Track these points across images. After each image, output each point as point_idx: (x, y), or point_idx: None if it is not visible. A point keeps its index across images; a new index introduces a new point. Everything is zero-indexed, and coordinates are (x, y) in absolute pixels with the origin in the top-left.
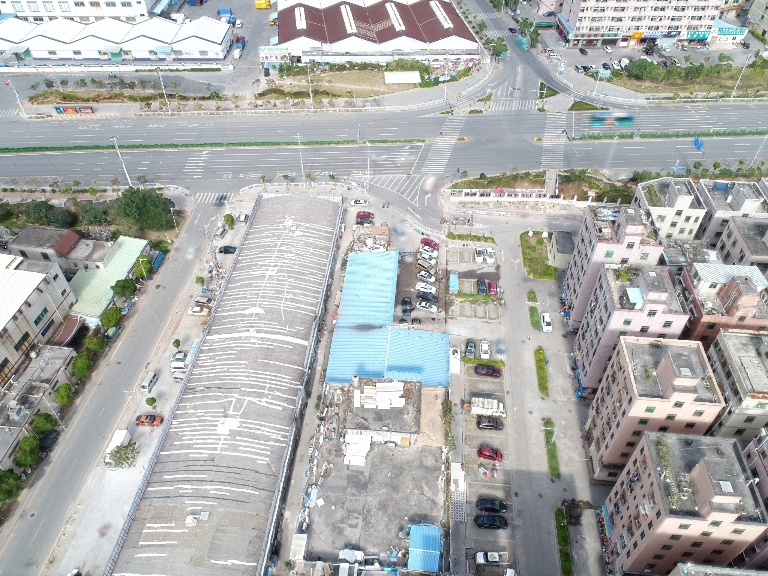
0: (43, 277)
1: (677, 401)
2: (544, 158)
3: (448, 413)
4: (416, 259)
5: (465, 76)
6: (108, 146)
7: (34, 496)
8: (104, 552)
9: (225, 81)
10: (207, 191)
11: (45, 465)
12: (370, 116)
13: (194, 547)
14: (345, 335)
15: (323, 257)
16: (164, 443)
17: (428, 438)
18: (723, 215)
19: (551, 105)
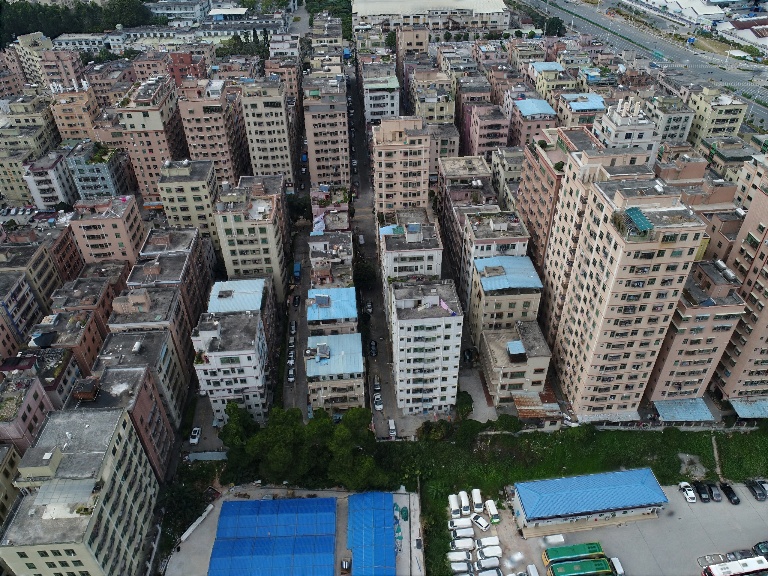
0: (503, 12)
1: None
2: None
3: None
4: None
5: (766, 64)
6: None
7: None
8: None
9: None
10: None
11: None
12: None
13: None
14: None
15: None
16: None
17: None
18: None
19: (762, 83)
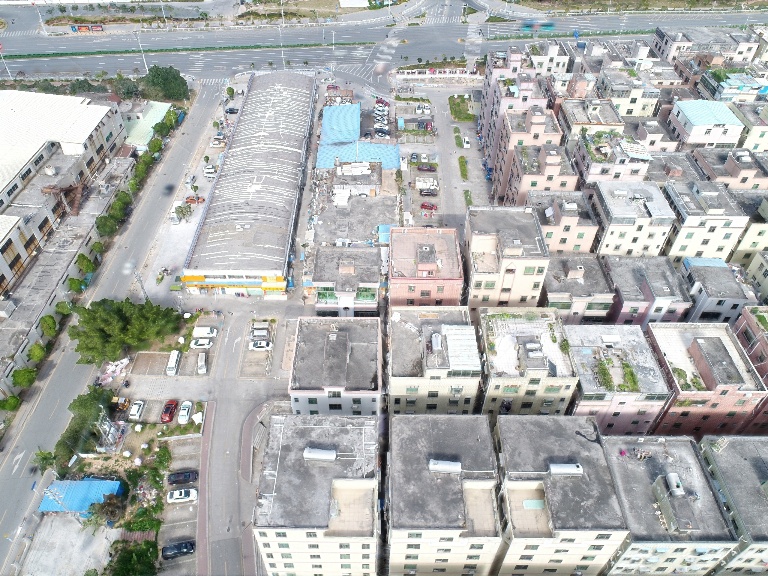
0: (109, 108)
1: (535, 133)
2: (466, 52)
3: (400, 178)
4: (373, 112)
5: (404, 1)
6: (122, 51)
7: (124, 239)
8: (180, 260)
9: (208, 8)
10: (209, 78)
11: (127, 224)
12: (330, 29)
13: (244, 239)
14: (326, 148)
15: (306, 107)
16: (211, 201)
17: (387, 192)
18: (580, 60)
19: (472, 19)
